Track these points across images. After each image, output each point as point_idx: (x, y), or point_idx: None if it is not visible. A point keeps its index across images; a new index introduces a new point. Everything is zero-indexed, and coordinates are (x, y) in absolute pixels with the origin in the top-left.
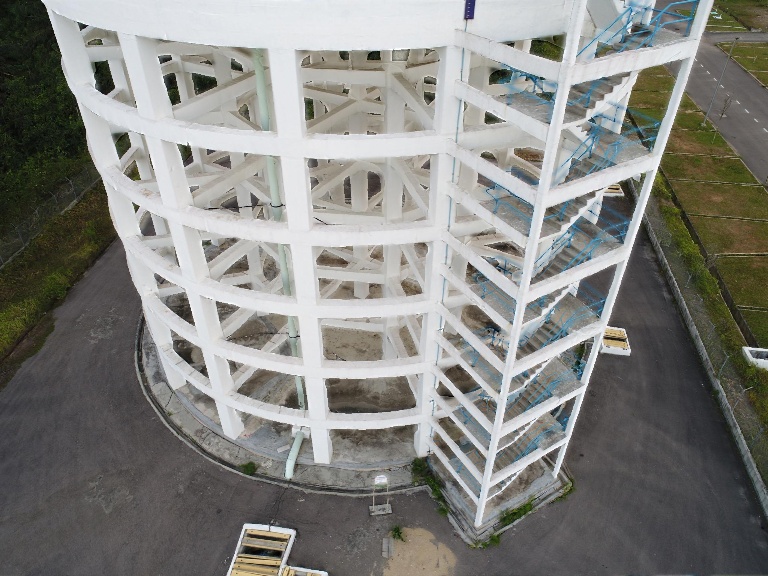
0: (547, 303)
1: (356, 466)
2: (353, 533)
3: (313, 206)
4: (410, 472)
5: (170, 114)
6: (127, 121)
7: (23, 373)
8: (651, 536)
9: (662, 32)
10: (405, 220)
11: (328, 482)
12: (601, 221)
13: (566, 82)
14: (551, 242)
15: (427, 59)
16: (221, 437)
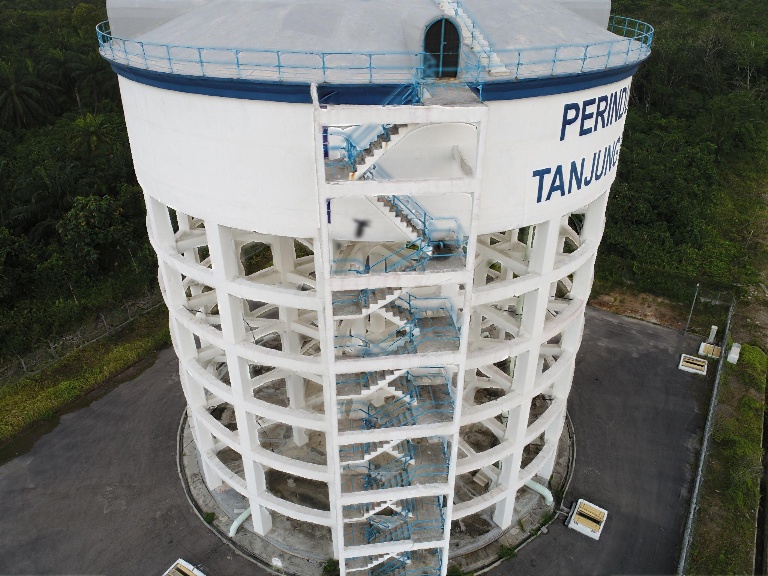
0: (370, 451)
1: (282, 546)
2: None
3: None
4: (322, 569)
5: (173, 244)
6: (152, 243)
7: (117, 392)
8: None
9: (457, 259)
10: (371, 350)
11: (256, 551)
12: (660, 395)
13: (325, 288)
14: None
15: None
16: (205, 485)
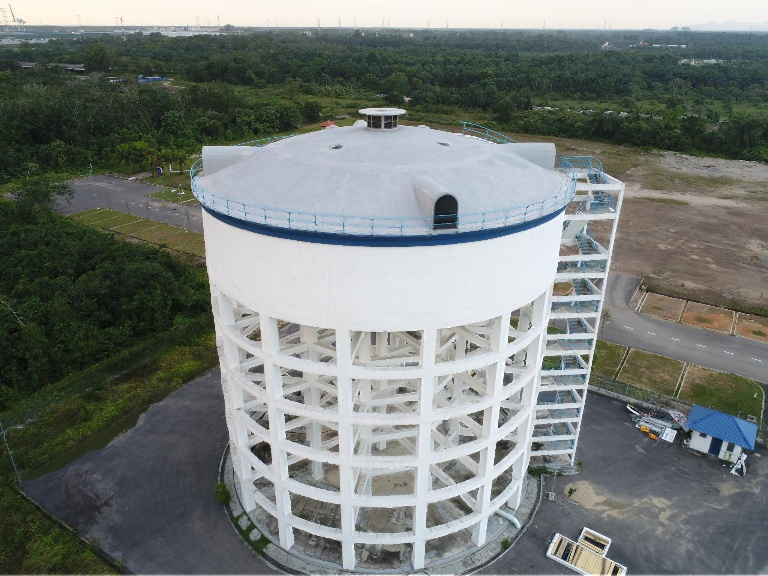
0: None
1: None
2: (562, 512)
3: None
4: (532, 477)
5: None
6: (489, 361)
7: None
8: (586, 420)
9: None
10: None
11: (528, 511)
12: None
13: None
14: None
15: None
16: (477, 551)
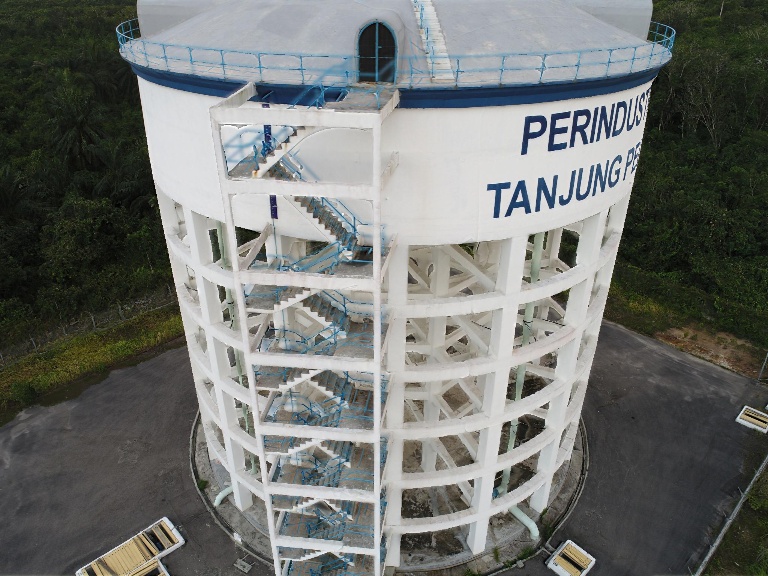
0: (294, 445)
1: (256, 525)
2: (213, 568)
3: None
4: None
5: (176, 226)
6: None
7: (163, 357)
8: None
9: None
10: None
11: (233, 524)
12: (703, 446)
13: (235, 280)
14: (400, 411)
15: None
16: (208, 454)
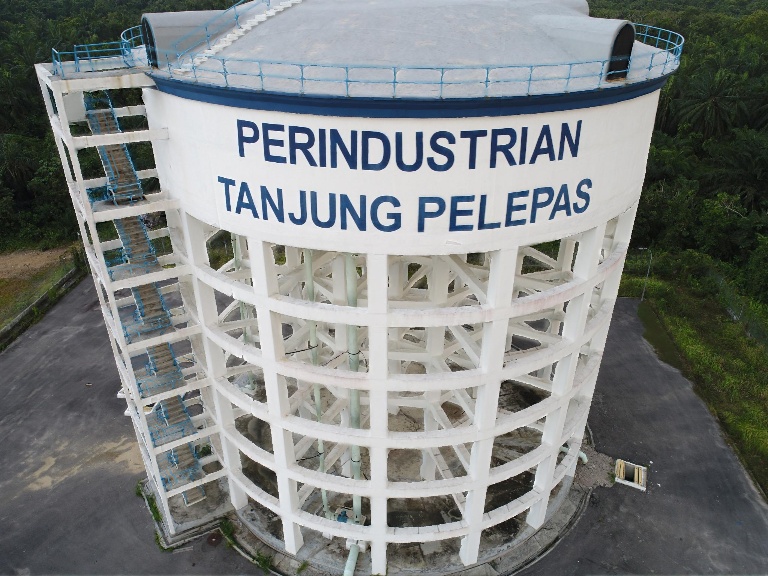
0: None
1: None
2: None
3: (536, 372)
4: None
5: None
6: None
7: None
8: None
9: (109, 207)
10: None
11: None
12: None
13: None
14: None
15: (522, 279)
16: None
